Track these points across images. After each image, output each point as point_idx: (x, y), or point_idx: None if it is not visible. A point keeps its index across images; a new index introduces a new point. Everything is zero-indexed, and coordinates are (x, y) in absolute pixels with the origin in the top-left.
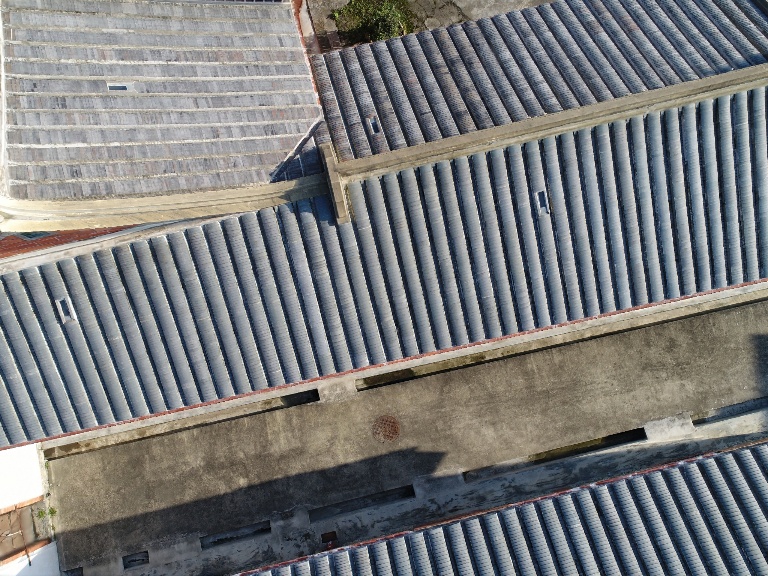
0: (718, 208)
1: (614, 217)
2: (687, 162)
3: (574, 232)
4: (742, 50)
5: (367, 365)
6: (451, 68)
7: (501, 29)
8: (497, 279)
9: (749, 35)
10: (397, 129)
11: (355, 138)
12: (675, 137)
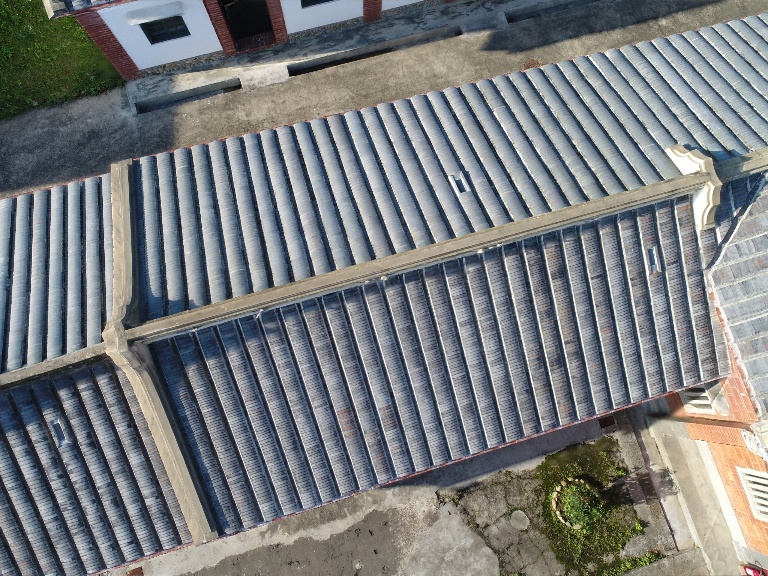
0: (259, 196)
1: (377, 179)
2: (299, 233)
3: (418, 165)
4: (226, 368)
5: (607, 51)
6: (561, 353)
7: (497, 420)
8: (493, 121)
9: (212, 394)
10: (629, 253)
11: (674, 241)
12: (317, 252)
